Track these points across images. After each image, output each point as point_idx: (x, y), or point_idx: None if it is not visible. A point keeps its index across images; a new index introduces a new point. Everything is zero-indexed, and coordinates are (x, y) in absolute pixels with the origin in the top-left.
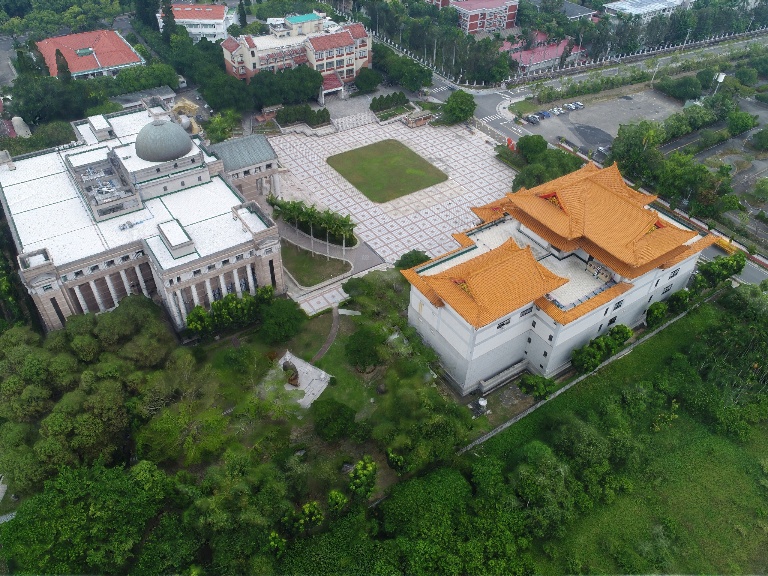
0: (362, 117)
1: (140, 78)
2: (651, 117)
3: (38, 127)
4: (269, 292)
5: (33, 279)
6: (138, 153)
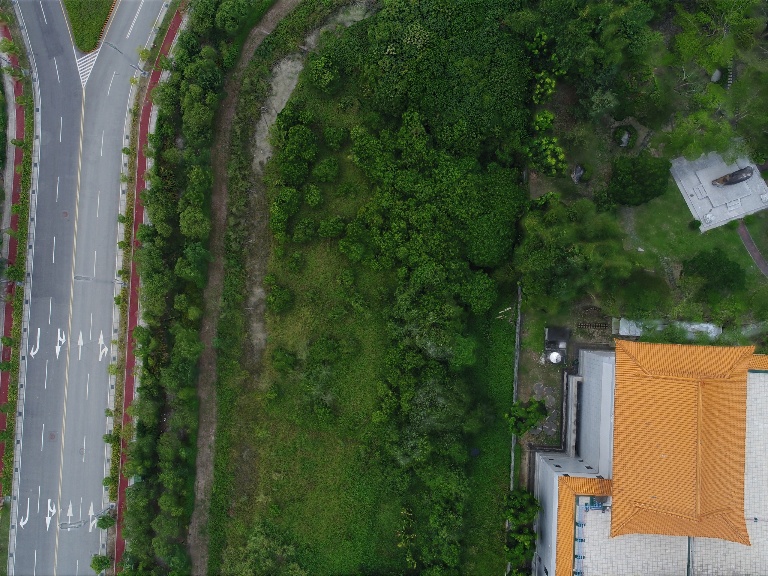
0: None
1: None
2: None
3: None
4: None
5: None
6: None
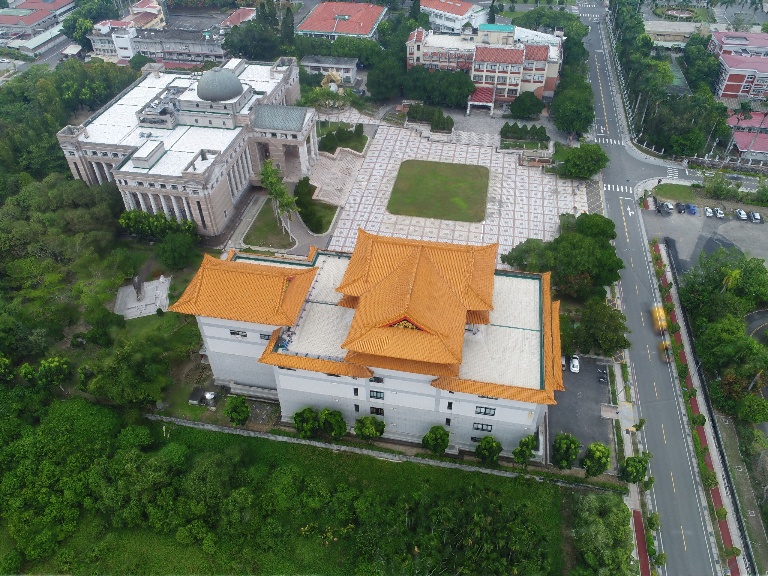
0: (487, 138)
1: (346, 47)
2: None
3: None
4: (187, 226)
5: (63, 143)
6: None
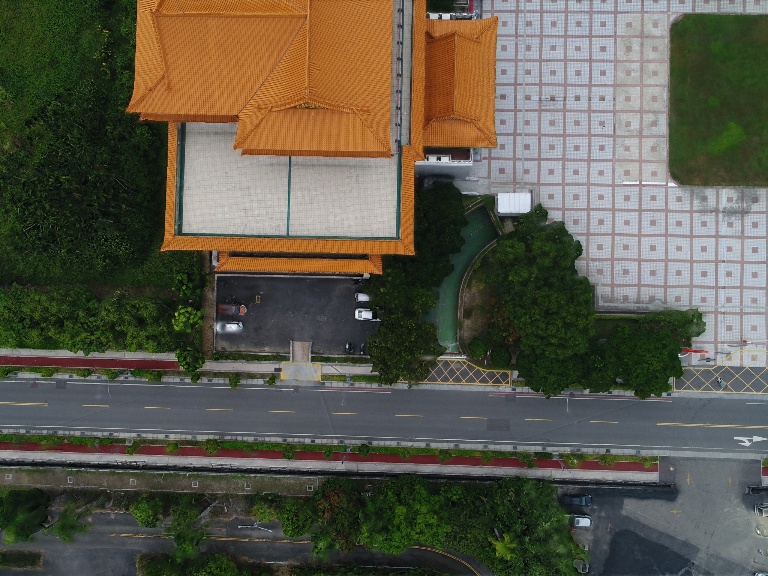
0: None
1: None
2: None
3: None
4: None
5: None
6: None
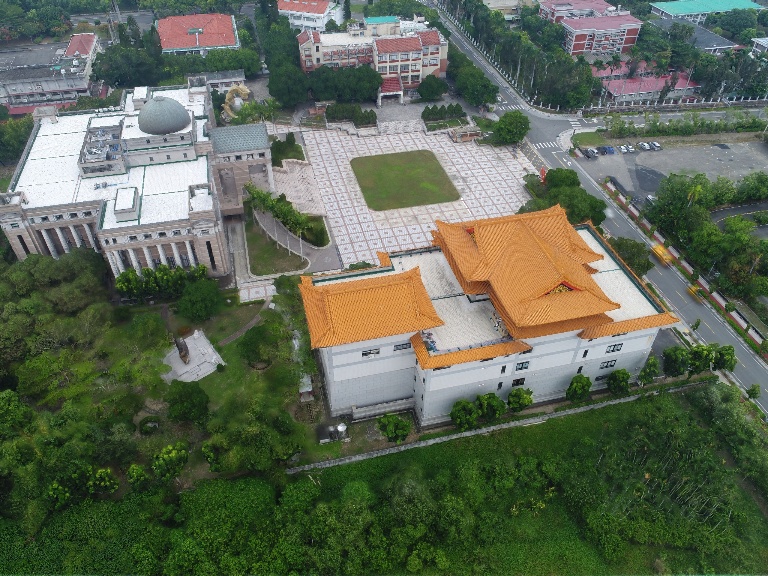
0: (411, 124)
1: (224, 60)
2: (739, 172)
3: (112, 91)
4: (201, 271)
5: (2, 215)
6: (138, 123)
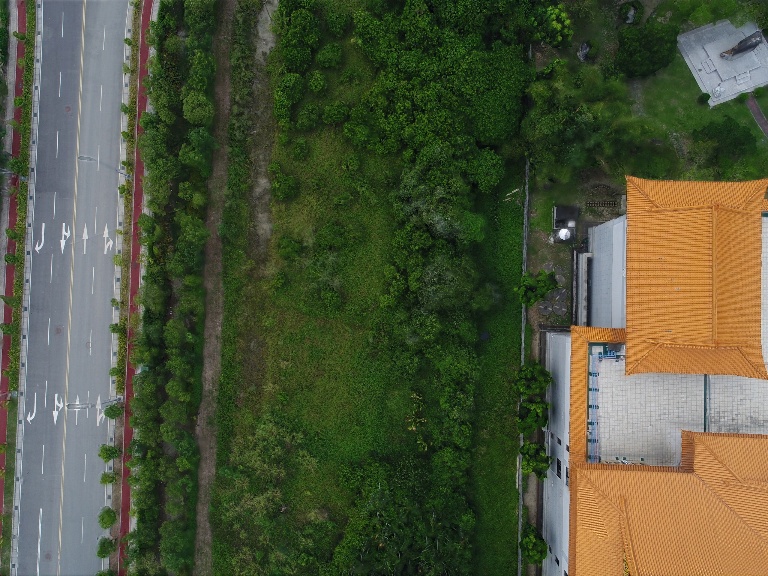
0: None
1: None
2: None
3: None
4: None
5: None
6: None
